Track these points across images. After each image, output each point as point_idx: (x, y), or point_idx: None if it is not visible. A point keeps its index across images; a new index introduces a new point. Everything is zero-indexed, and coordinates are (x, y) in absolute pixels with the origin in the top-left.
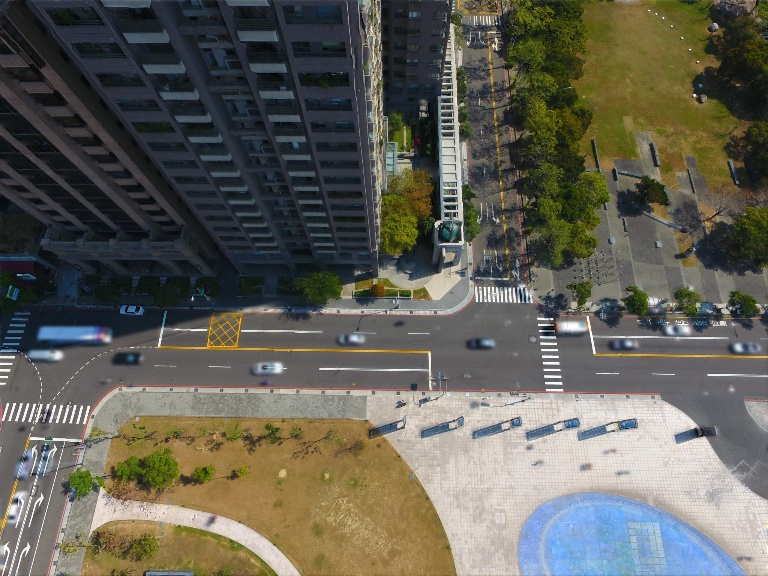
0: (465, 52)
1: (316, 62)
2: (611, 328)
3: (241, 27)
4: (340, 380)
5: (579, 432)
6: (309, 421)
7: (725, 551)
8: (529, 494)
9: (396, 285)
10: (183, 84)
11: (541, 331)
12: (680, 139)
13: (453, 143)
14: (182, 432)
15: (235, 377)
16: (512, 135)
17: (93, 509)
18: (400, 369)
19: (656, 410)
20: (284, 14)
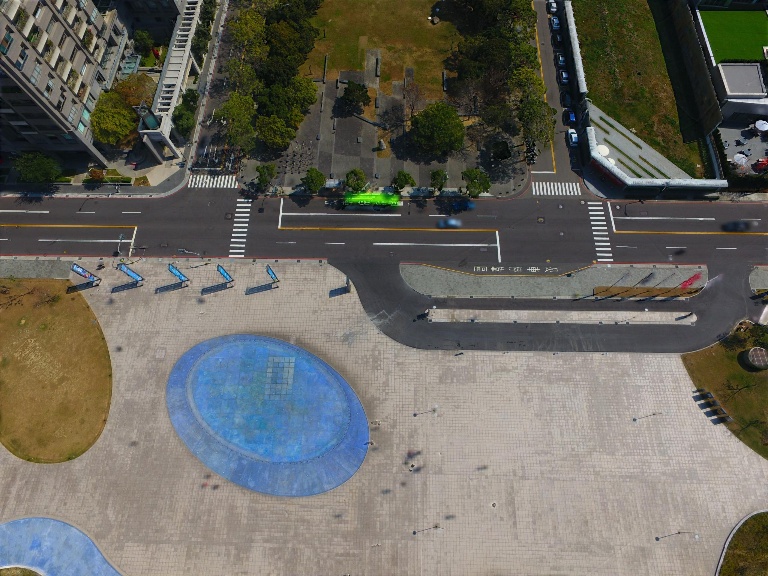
0: None
1: None
2: (300, 207)
3: None
4: (54, 249)
5: (248, 288)
6: (19, 280)
7: (344, 378)
8: (190, 336)
9: (121, 174)
10: None
11: (238, 210)
12: (405, 54)
13: (183, 53)
14: None
15: None
16: None
17: None
18: (107, 240)
19: (320, 271)
20: None
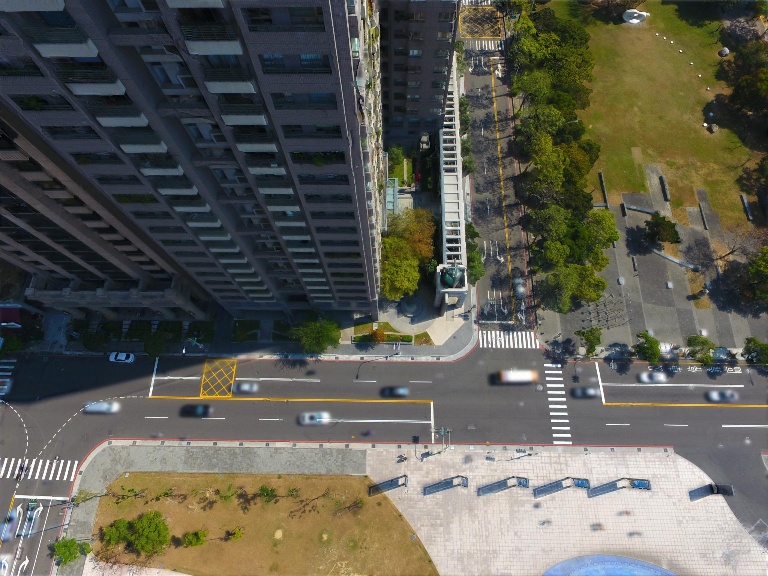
0: (467, 79)
1: (309, 143)
2: (621, 375)
3: (226, 111)
4: (339, 432)
5: None
6: (306, 477)
7: None
8: (537, 556)
9: (397, 329)
10: (165, 161)
11: (548, 379)
12: (691, 171)
13: (456, 179)
14: (174, 489)
15: (229, 429)
16: (516, 167)
17: (80, 574)
18: (401, 420)
19: (669, 464)
20: (273, 101)
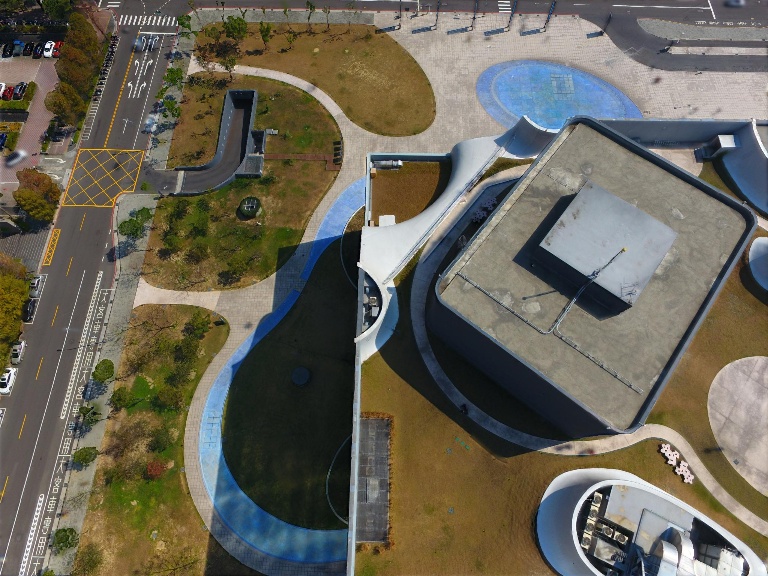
0: None
1: None
2: None
3: None
4: (355, 5)
5: (521, 32)
6: (334, 25)
7: (614, 86)
8: (485, 61)
9: None
10: None
11: None
12: None
13: None
14: None
15: (281, 3)
16: None
17: (188, 65)
18: (397, 0)
19: (575, 22)
20: None
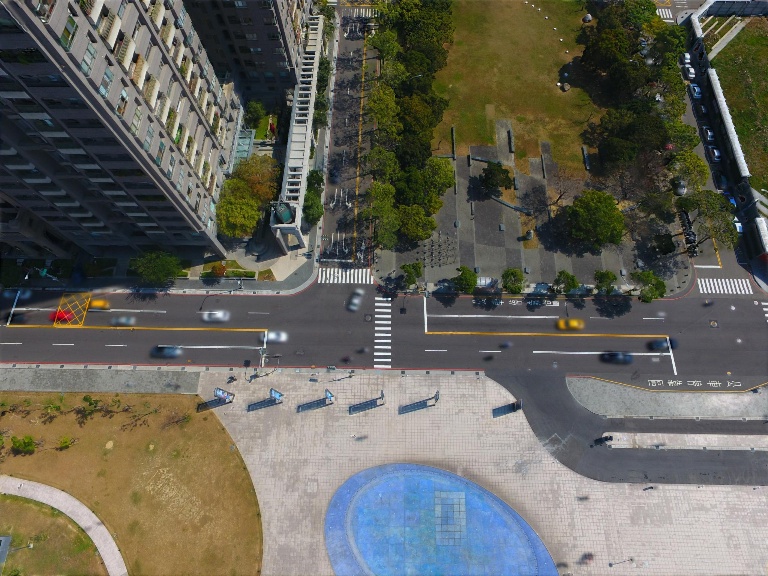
0: (341, 43)
1: None
2: (446, 307)
3: None
4: (177, 357)
5: (400, 406)
6: (141, 395)
7: (524, 519)
8: (343, 465)
9: (243, 267)
10: None
11: (377, 310)
12: (538, 126)
13: (305, 130)
14: (18, 406)
15: (76, 354)
16: (376, 123)
17: None
18: (236, 346)
19: (478, 385)
20: None
